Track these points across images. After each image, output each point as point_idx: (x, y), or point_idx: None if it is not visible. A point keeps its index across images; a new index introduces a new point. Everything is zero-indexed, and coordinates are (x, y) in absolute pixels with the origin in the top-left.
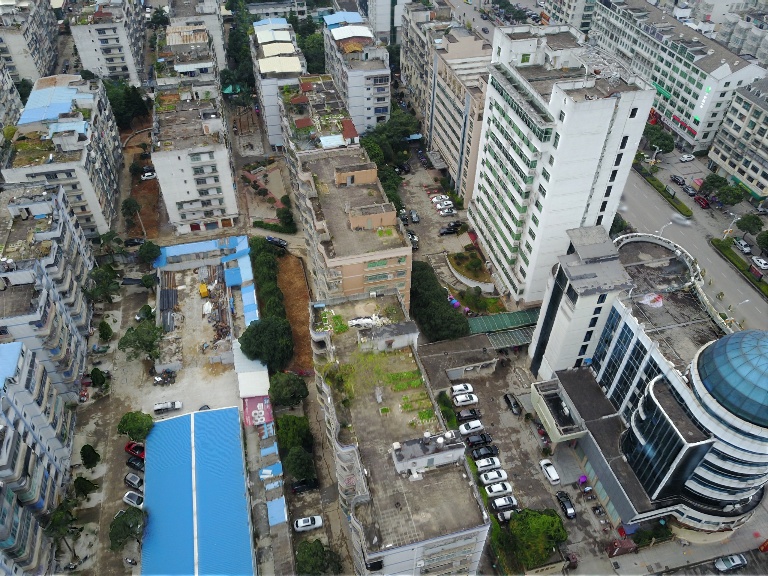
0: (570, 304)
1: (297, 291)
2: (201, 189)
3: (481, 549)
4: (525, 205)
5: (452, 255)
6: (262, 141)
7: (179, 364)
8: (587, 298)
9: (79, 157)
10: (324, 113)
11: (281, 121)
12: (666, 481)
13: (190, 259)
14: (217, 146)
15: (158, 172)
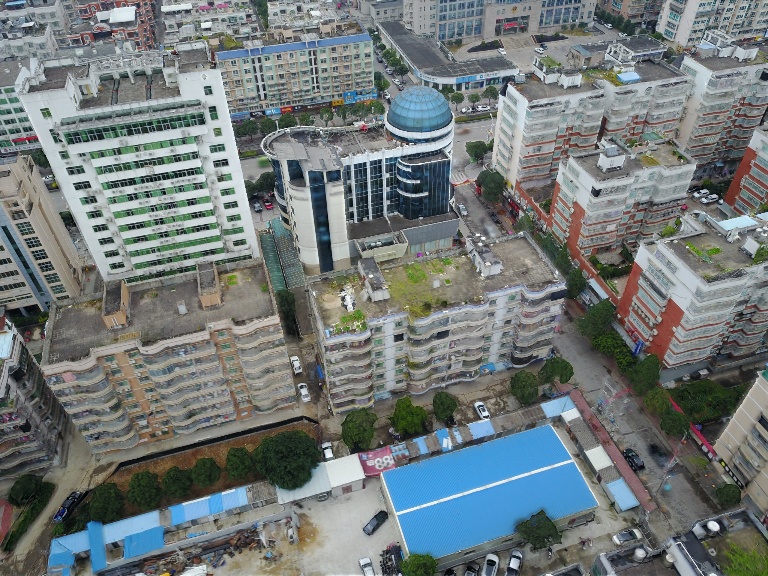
0: (338, 183)
1: (182, 465)
2: None
3: None
4: None
5: None
6: None
7: None
8: None
9: None
10: None
11: None
12: None
13: None
14: None
15: None
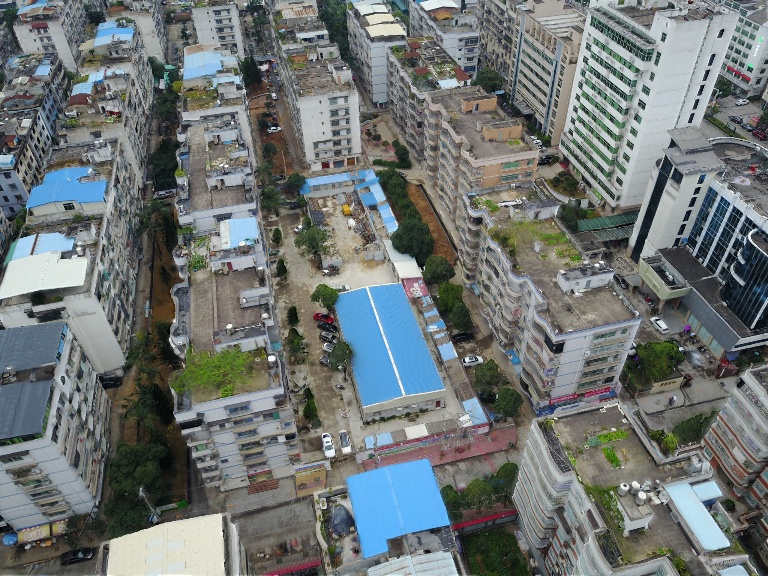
0: (675, 185)
1: (423, 209)
2: (334, 130)
3: (629, 348)
4: (624, 121)
5: (548, 180)
6: (363, 101)
7: (341, 260)
8: (691, 177)
9: (242, 102)
10: (436, 63)
11: (391, 76)
12: (764, 309)
13: (327, 189)
14: (351, 91)
15: (302, 115)
